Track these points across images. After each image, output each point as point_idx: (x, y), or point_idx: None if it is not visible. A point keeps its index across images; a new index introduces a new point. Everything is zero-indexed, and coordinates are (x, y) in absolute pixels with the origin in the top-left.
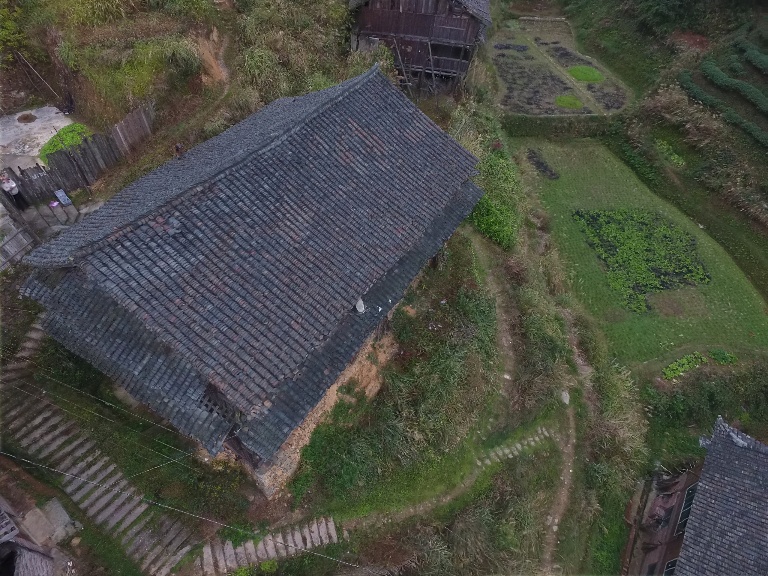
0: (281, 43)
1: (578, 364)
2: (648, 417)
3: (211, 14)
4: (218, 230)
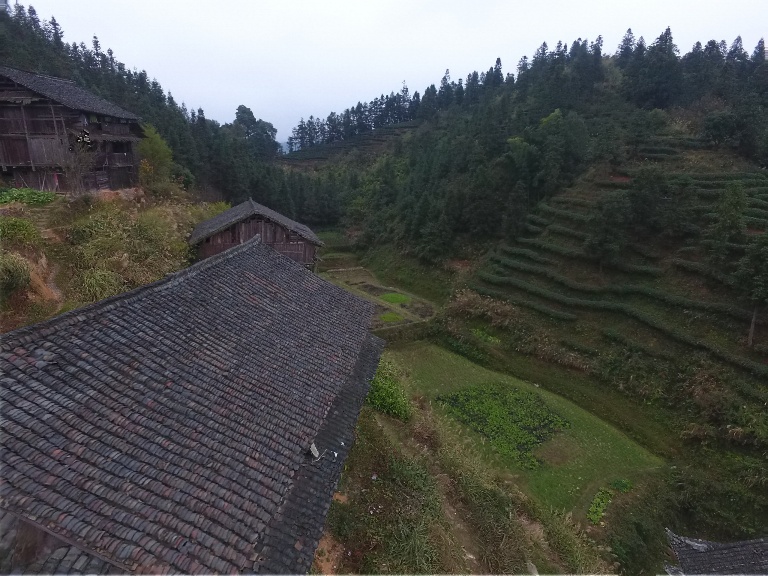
0: (126, 265)
1: (523, 525)
2: (615, 558)
3: (40, 243)
4: (114, 361)
